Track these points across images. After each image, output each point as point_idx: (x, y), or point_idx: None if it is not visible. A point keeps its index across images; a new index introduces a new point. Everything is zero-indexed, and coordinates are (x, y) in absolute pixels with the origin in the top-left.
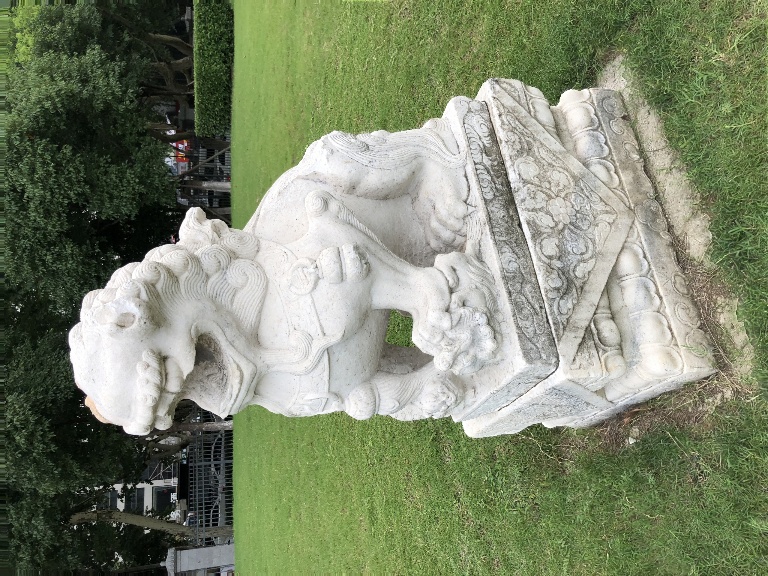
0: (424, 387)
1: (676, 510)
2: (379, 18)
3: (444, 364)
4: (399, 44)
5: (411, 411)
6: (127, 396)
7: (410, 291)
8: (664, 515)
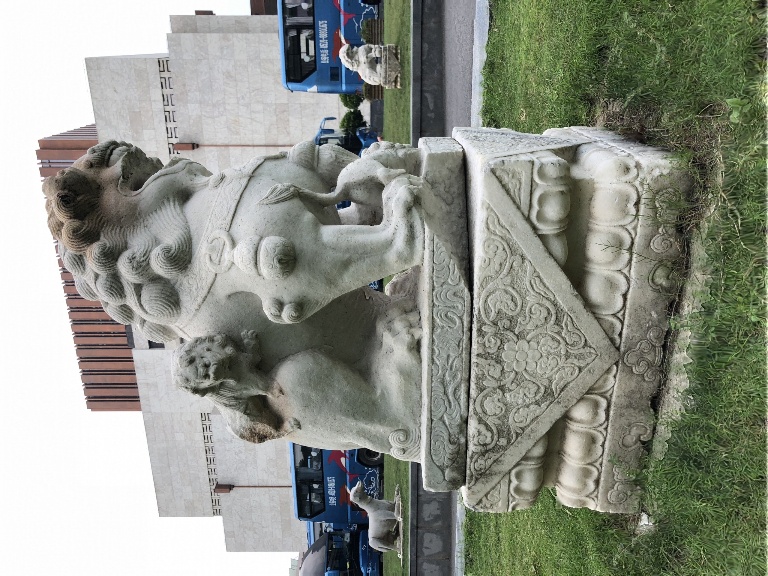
0: None
1: None
2: None
3: None
4: None
5: None
6: None
7: None
8: None
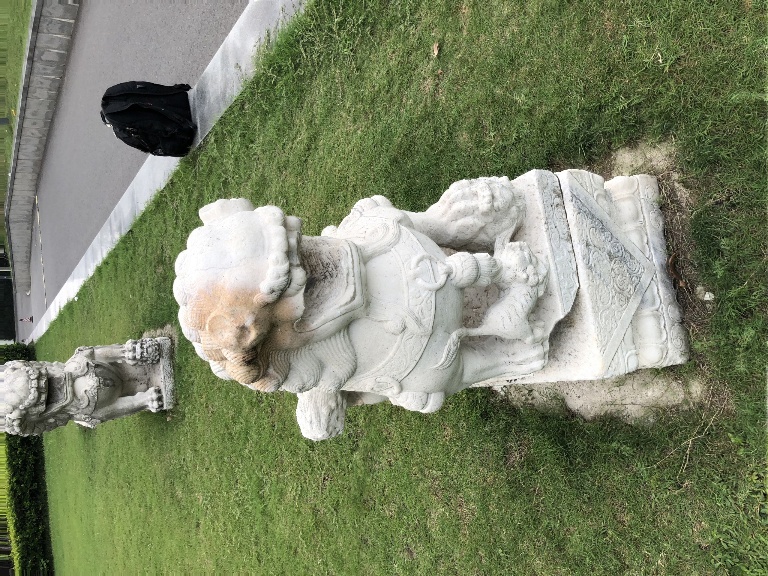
0: (500, 259)
1: (759, 230)
2: (306, 526)
3: (485, 189)
4: (334, 503)
5: (513, 298)
6: (255, 225)
7: (430, 211)
8: (761, 241)
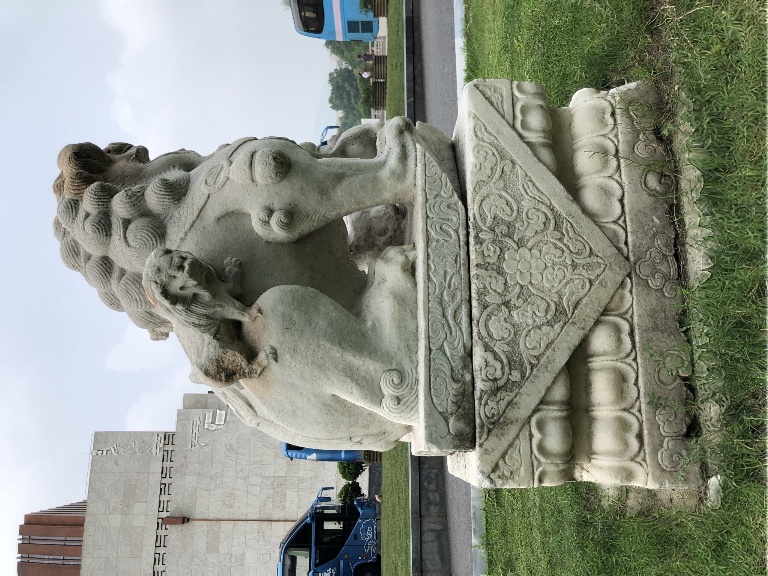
0: None
1: None
2: None
3: None
4: None
5: None
6: None
7: None
8: None
